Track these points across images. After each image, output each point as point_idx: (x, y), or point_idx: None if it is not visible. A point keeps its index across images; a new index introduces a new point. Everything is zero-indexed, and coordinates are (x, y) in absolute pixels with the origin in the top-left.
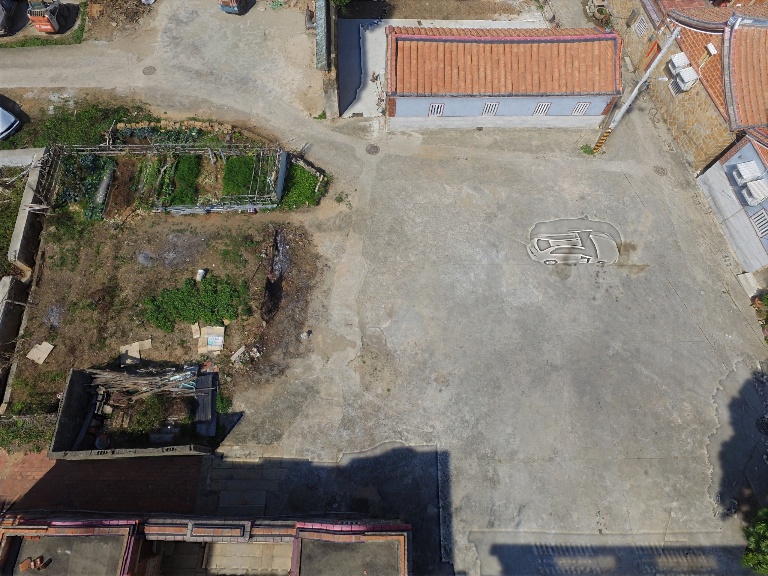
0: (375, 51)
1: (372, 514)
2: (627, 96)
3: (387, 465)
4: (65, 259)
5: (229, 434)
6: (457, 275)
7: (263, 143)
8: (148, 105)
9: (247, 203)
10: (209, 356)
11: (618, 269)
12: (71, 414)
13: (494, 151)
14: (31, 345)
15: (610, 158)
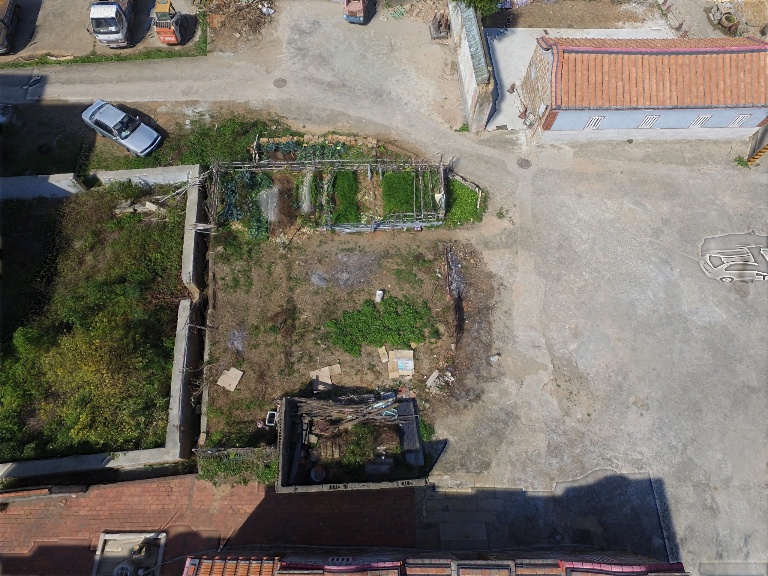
0: (506, 61)
1: (598, 546)
2: None
3: (603, 494)
4: (238, 280)
5: (437, 463)
6: (635, 294)
7: (409, 157)
8: (285, 118)
9: (413, 220)
10: (401, 381)
11: None
12: (286, 445)
13: (648, 164)
14: (219, 371)
15: (765, 170)
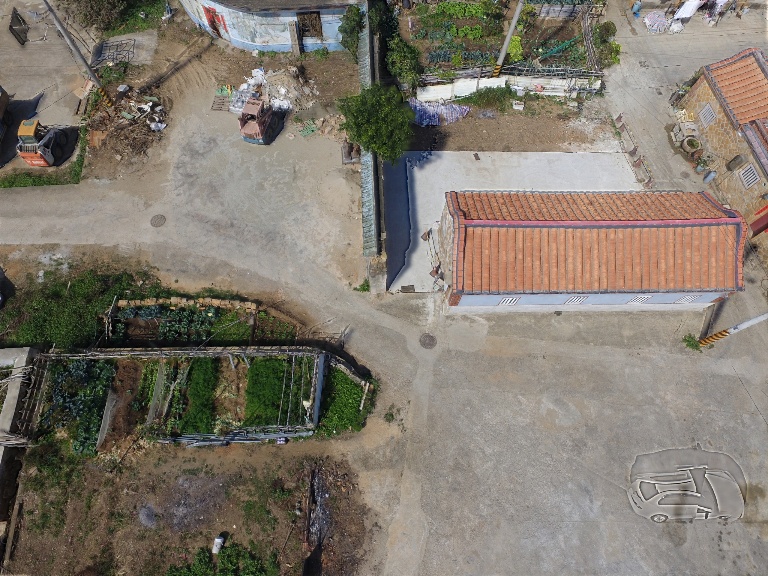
0: (425, 196)
1: None
2: None
3: None
4: (48, 517)
5: None
6: (542, 539)
7: (294, 326)
8: (156, 270)
9: (276, 430)
10: None
11: (746, 528)
12: None
13: (577, 345)
14: None
15: (720, 355)
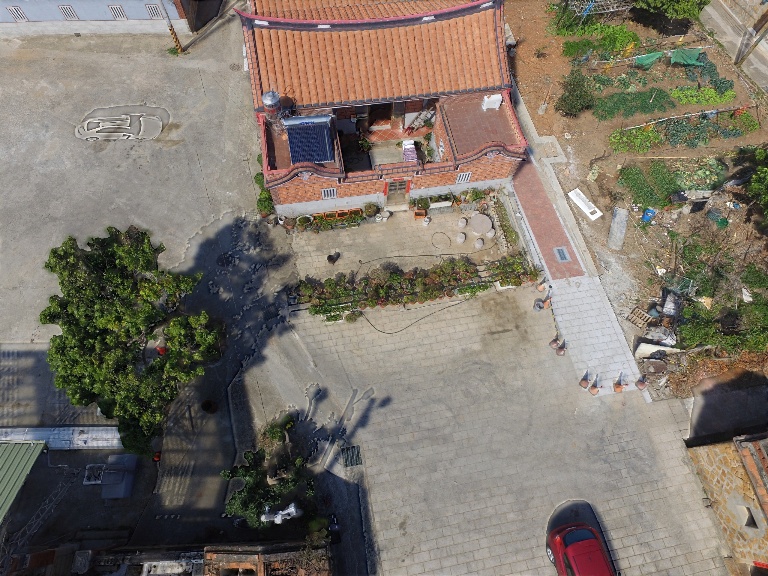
0: None
1: None
2: None
3: None
4: None
5: None
6: None
7: None
8: None
9: None
10: None
11: (154, 144)
12: None
13: (83, 53)
14: None
15: (192, 57)
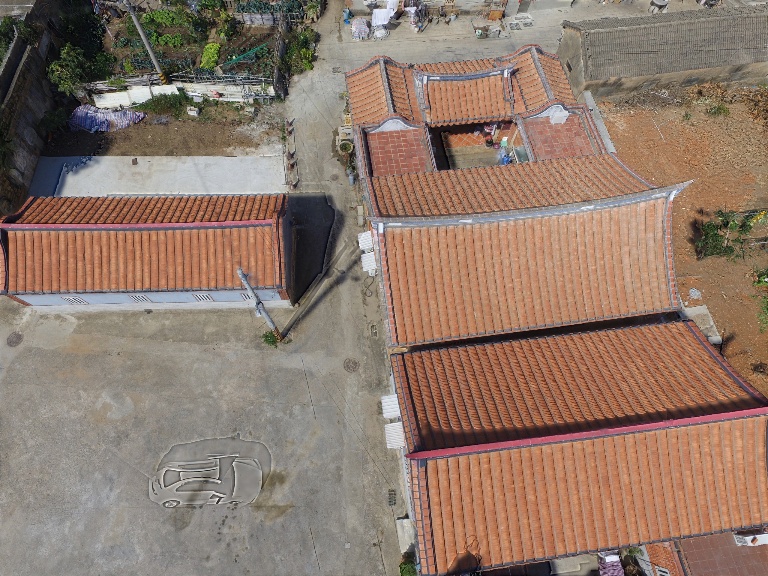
0: None
1: None
2: (344, 260)
3: None
4: None
5: None
6: (49, 525)
7: None
8: None
9: None
10: None
11: (252, 512)
12: None
13: (156, 342)
14: None
15: (294, 349)
